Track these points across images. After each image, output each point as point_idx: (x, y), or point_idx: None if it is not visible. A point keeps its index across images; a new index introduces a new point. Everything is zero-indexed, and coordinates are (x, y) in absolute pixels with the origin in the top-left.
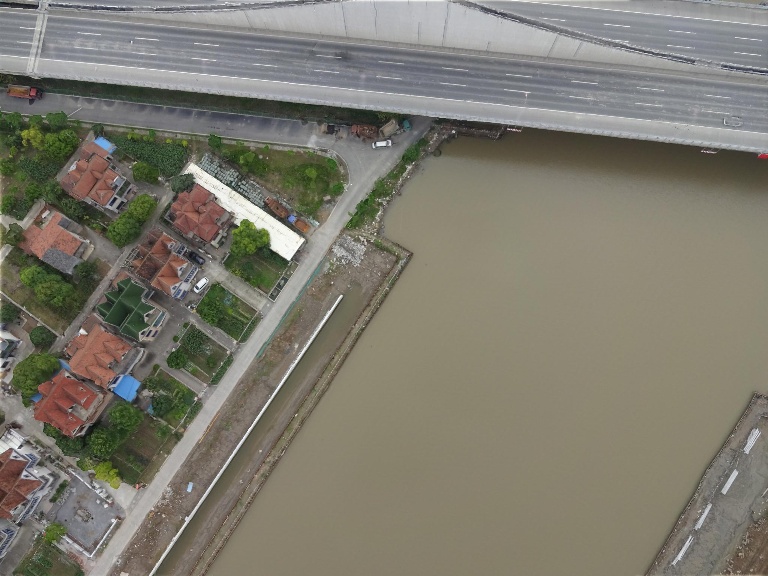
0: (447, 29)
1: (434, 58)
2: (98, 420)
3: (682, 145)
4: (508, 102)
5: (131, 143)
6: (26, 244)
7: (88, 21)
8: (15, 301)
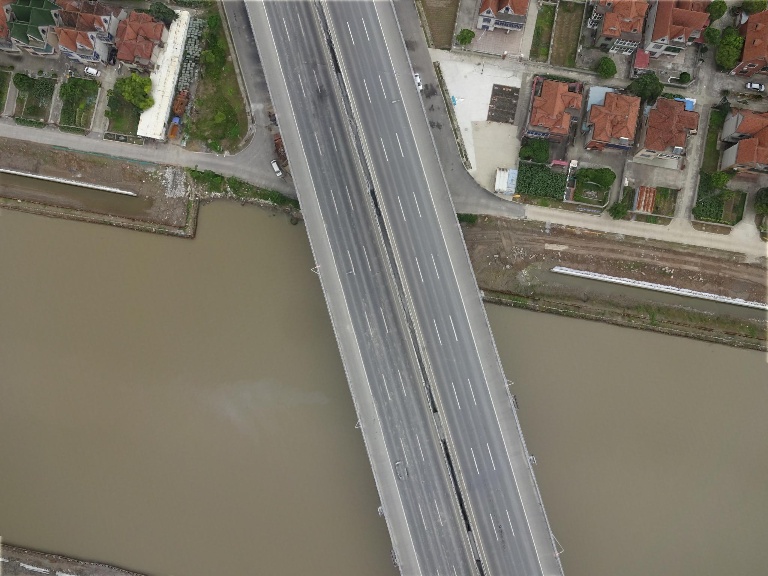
0: None
1: (353, 175)
2: None
3: (361, 432)
4: (337, 259)
5: None
6: None
7: None
8: None
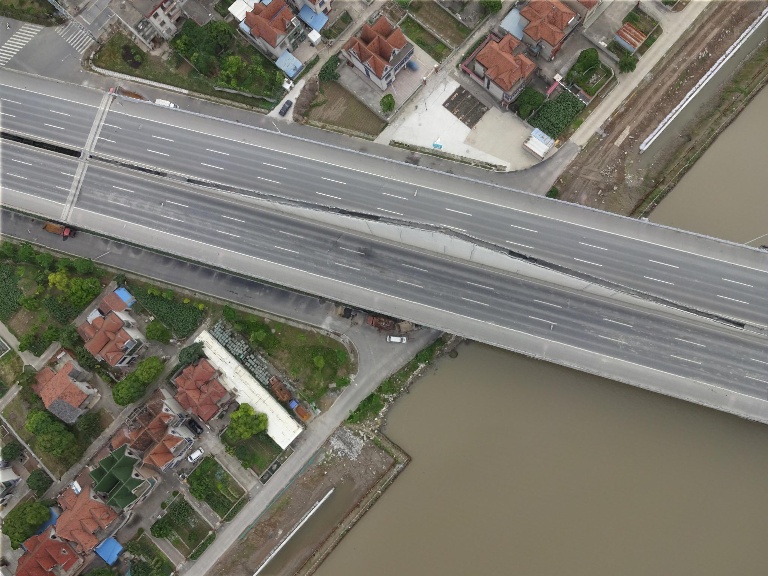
0: (474, 254)
1: (460, 270)
2: (78, 575)
3: None
4: (531, 331)
5: (150, 298)
6: (37, 387)
7: (124, 176)
8: (21, 437)
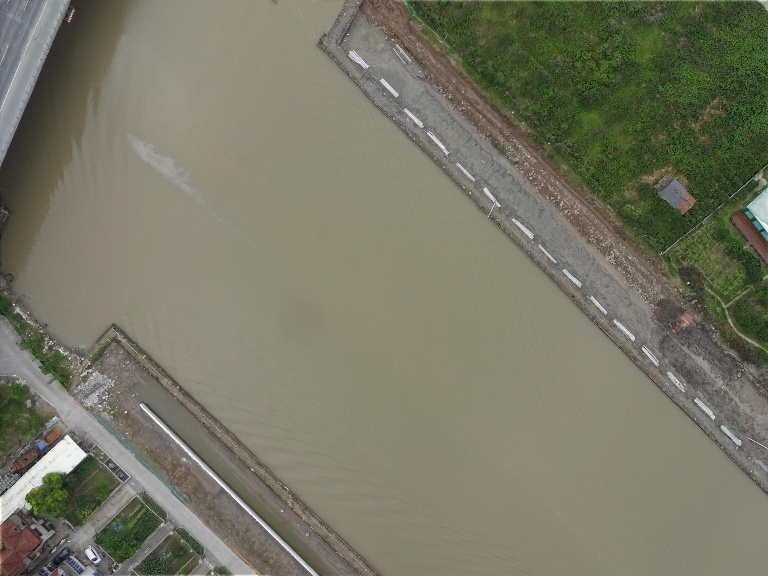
0: None
1: None
2: None
3: None
4: None
5: None
6: None
7: None
8: None
